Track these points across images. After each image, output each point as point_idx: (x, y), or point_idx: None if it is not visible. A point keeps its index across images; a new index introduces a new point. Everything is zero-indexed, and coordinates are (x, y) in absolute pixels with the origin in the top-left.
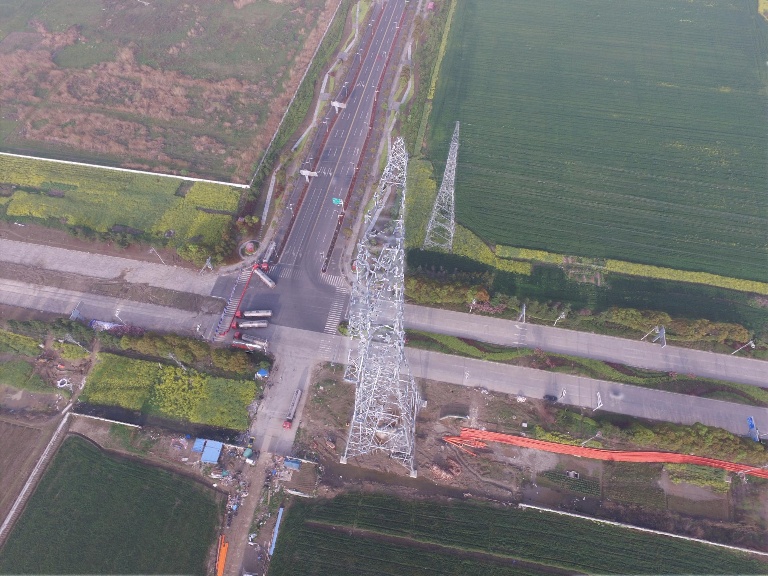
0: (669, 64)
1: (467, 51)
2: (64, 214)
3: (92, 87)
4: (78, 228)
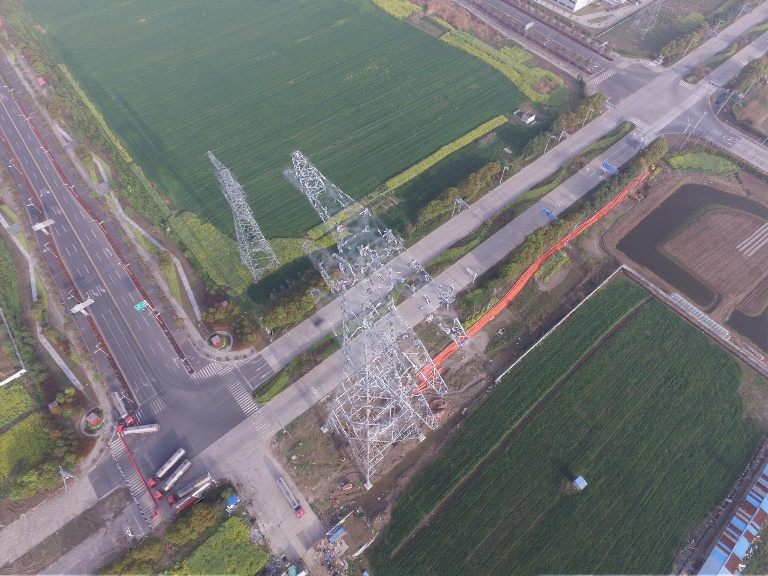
0: (289, 24)
1: (121, 102)
2: None
3: None
4: None
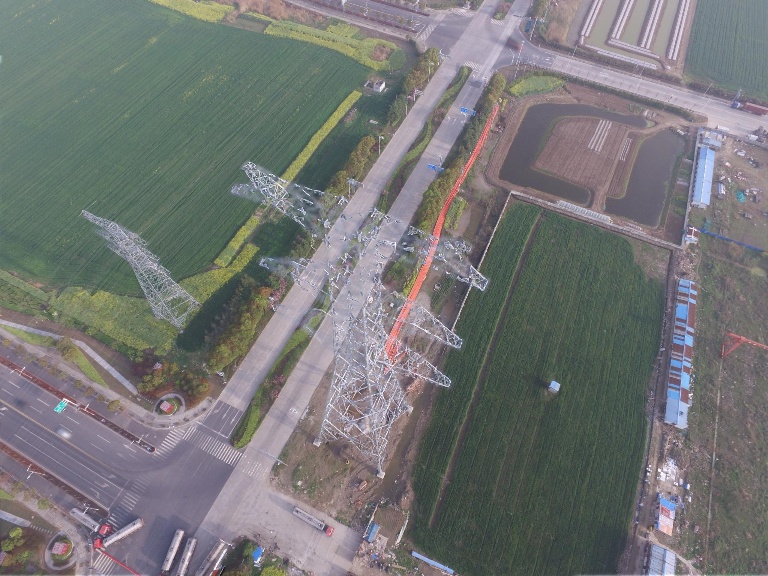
0: (96, 56)
1: None
2: None
3: None
4: None
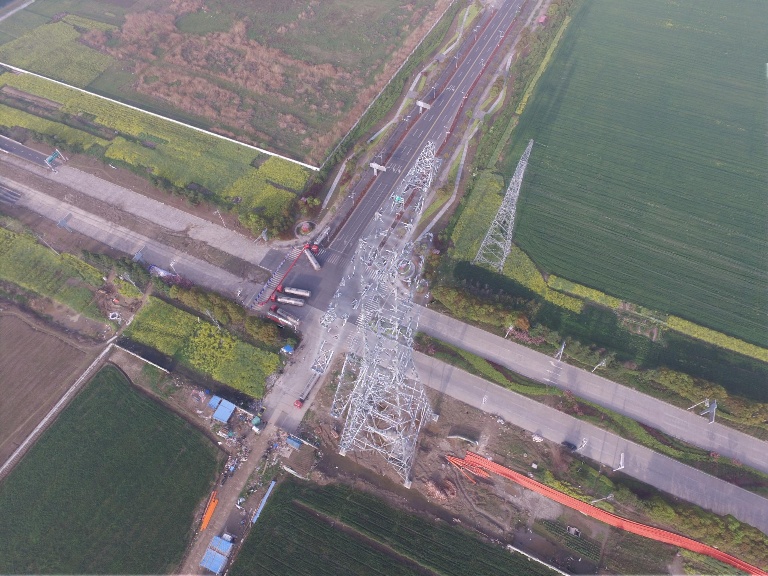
0: None
1: (569, 71)
2: (151, 164)
3: (203, 53)
4: (160, 179)
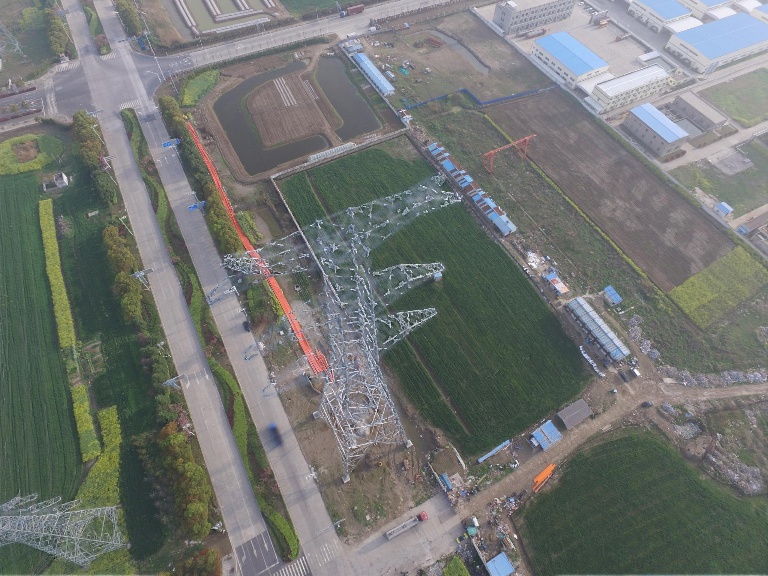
0: None
1: None
2: None
3: None
4: None
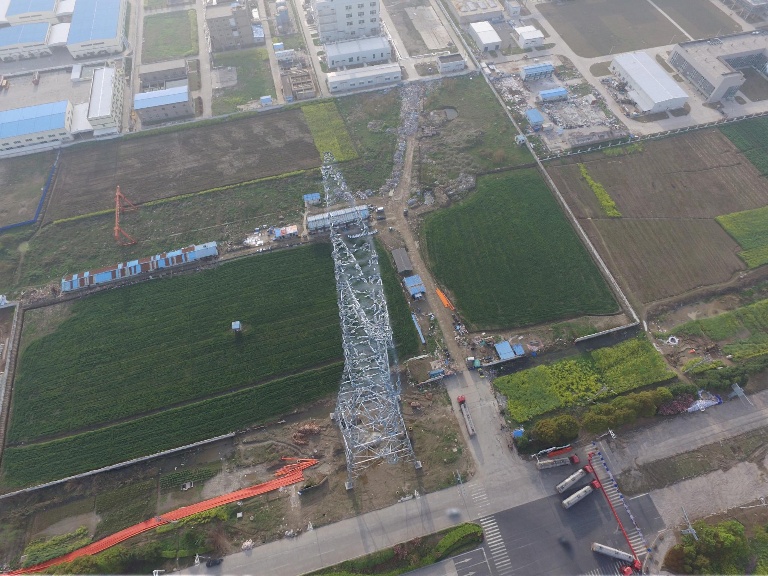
0: None
1: None
2: None
3: None
4: None
